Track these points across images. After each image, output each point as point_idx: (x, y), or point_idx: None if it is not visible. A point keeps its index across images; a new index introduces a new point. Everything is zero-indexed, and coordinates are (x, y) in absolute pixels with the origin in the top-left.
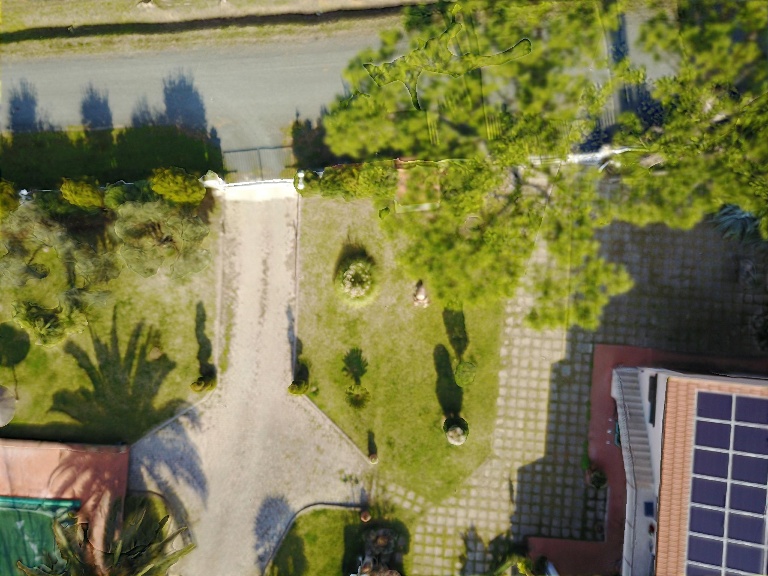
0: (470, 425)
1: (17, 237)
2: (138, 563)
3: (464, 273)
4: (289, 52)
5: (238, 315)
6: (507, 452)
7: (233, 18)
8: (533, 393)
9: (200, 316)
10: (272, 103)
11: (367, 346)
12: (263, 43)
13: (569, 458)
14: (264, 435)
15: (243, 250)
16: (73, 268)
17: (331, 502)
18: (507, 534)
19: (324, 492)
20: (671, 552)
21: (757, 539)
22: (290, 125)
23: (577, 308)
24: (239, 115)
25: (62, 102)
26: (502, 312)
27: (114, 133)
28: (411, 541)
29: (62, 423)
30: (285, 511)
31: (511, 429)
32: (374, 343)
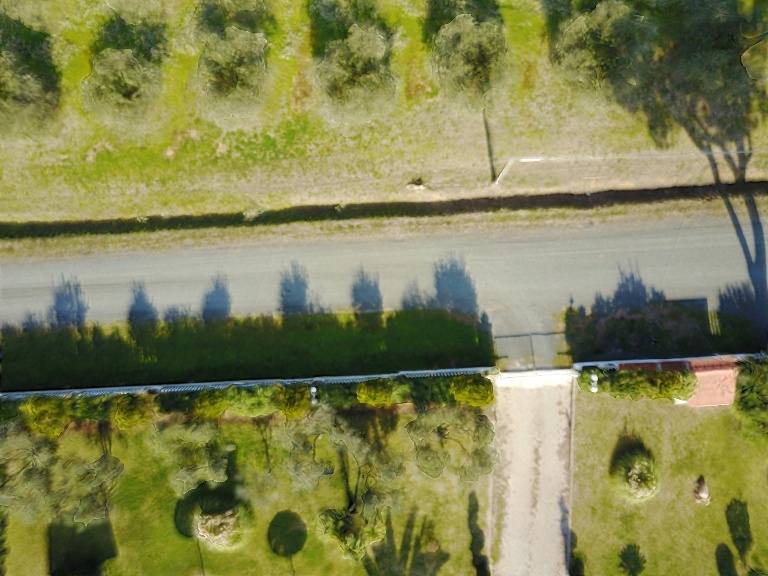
0: None
1: (307, 436)
2: None
3: (748, 471)
4: (564, 237)
5: (510, 505)
6: None
7: (501, 198)
8: None
9: (473, 506)
10: (545, 289)
11: (645, 542)
12: (537, 227)
13: None
14: None
15: (514, 438)
16: (346, 455)
17: None
18: None
19: None
20: None
21: None
22: (564, 311)
23: None
24: (511, 300)
25: (333, 285)
26: None
27: (384, 316)
28: None
29: None
30: None
31: None
32: (653, 540)
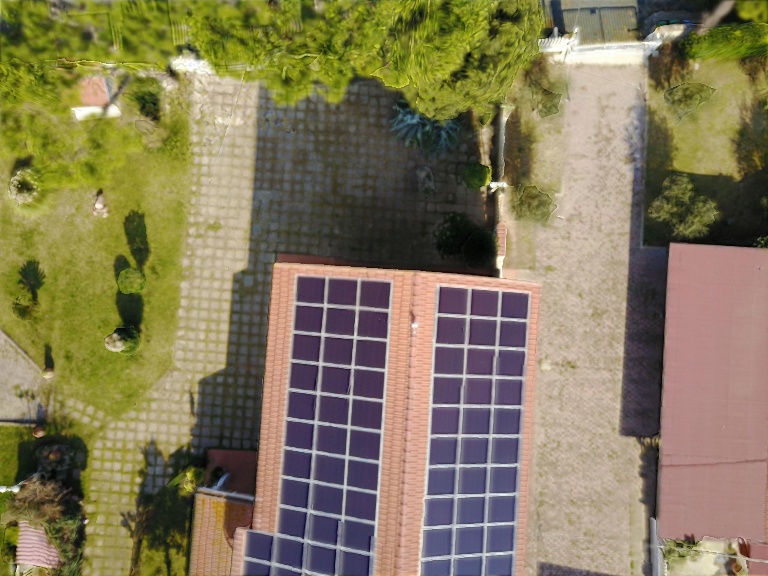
0: (151, 337)
1: None
2: None
3: (146, 182)
4: None
5: None
6: (188, 364)
7: None
8: (215, 304)
9: None
10: None
11: (45, 258)
12: None
13: (251, 369)
14: None
15: None
16: None
17: (5, 419)
18: (187, 447)
19: None
20: (270, 439)
21: (341, 420)
22: None
23: (261, 217)
24: None
25: None
26: (185, 222)
27: None
28: (89, 457)
29: None
30: None
31: (192, 341)
32: (52, 254)
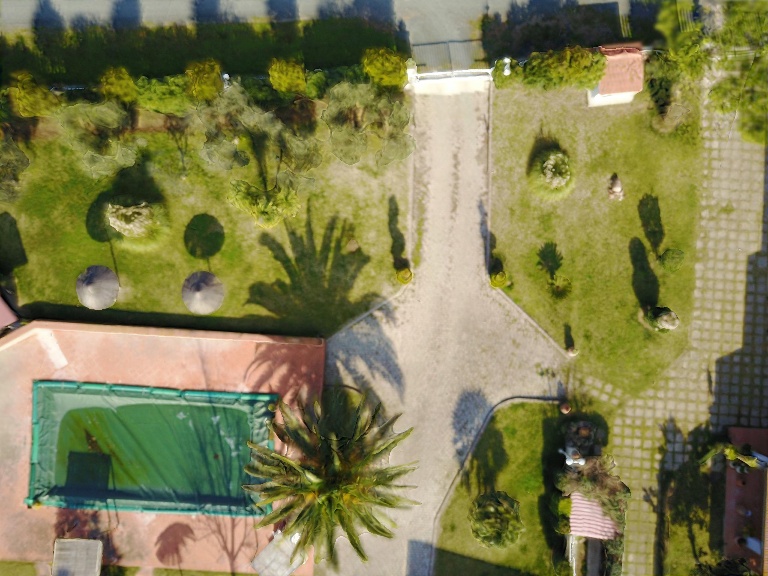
0: None
1: (221, 122)
2: (363, 445)
3: (659, 166)
4: None
5: (430, 210)
6: (705, 343)
7: None
8: (730, 285)
9: (393, 210)
10: None
11: (562, 240)
12: None
13: (767, 348)
14: (459, 330)
15: (434, 144)
16: (264, 161)
17: (528, 396)
18: (706, 425)
19: (520, 386)
20: None
21: None
22: (480, 18)
23: None
24: (428, 7)
25: None
26: (698, 204)
27: (301, 25)
28: (609, 433)
29: (259, 316)
30: (482, 405)
31: (709, 320)
32: (569, 237)
